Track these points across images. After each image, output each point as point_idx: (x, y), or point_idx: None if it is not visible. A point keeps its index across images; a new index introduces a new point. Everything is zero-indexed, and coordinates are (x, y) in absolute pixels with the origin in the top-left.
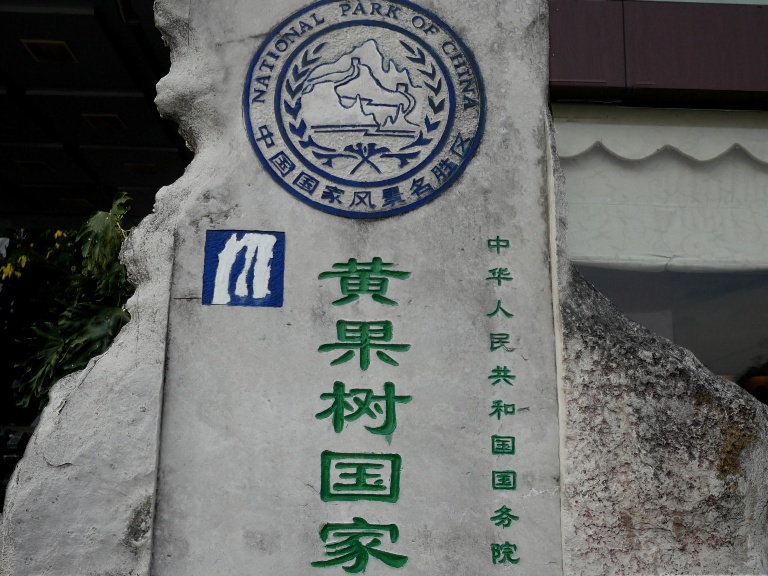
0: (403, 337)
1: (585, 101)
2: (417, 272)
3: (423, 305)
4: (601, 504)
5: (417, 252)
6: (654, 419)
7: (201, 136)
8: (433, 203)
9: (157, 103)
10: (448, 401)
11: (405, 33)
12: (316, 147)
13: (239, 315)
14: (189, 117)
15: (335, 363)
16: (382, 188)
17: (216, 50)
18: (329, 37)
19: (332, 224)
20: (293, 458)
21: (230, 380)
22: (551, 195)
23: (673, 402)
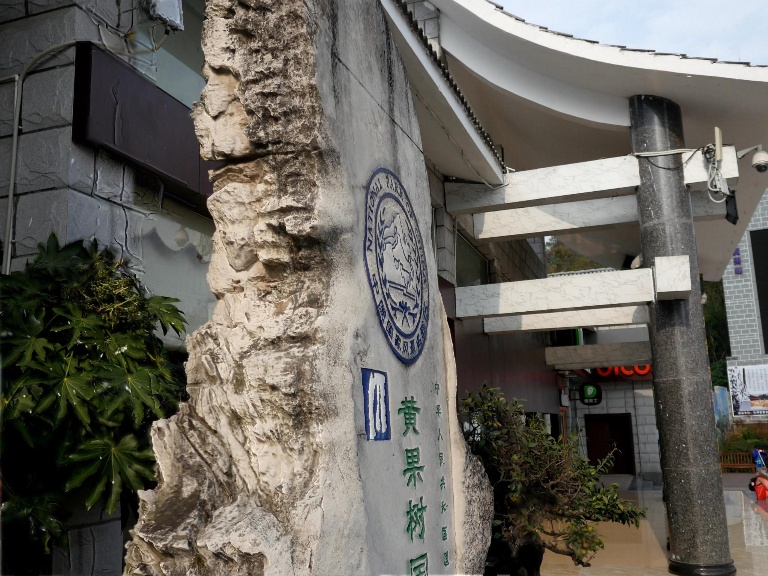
0: (422, 460)
1: (180, 199)
2: (422, 408)
3: (425, 434)
4: (471, 563)
5: (421, 393)
6: (482, 503)
7: (338, 270)
8: (422, 354)
9: (319, 228)
10: (434, 506)
11: (406, 214)
12: (391, 300)
13: (379, 449)
14: (334, 249)
15: (408, 485)
16: (410, 340)
17: (353, 192)
18: (385, 203)
19: (399, 368)
20: (404, 570)
21: (380, 510)
22: (450, 355)
23: (486, 492)
